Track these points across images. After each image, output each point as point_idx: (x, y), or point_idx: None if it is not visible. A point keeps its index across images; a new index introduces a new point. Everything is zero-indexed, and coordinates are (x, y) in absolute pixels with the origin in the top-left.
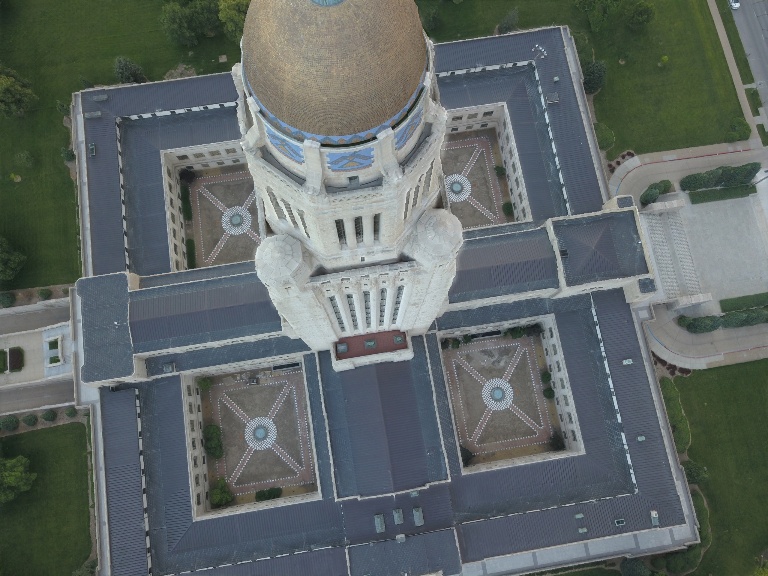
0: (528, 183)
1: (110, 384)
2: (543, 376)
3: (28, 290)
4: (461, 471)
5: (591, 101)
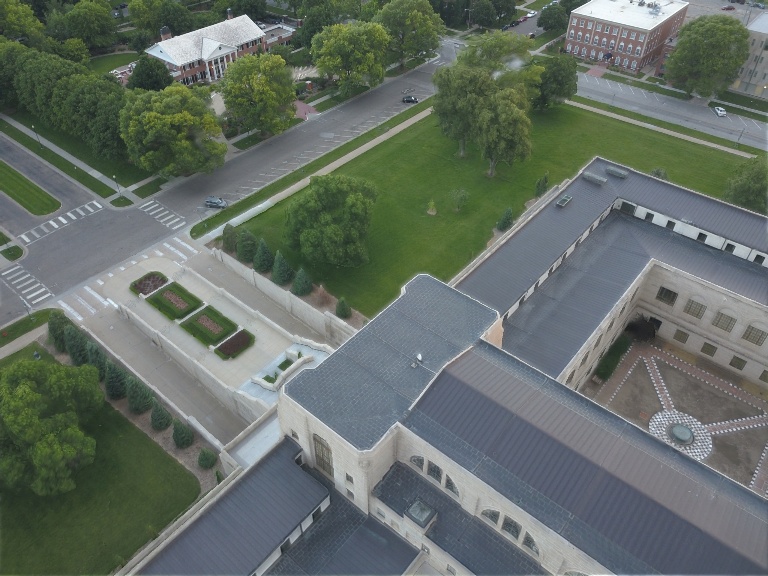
0: None
1: (308, 443)
2: None
3: (331, 297)
4: None
5: None
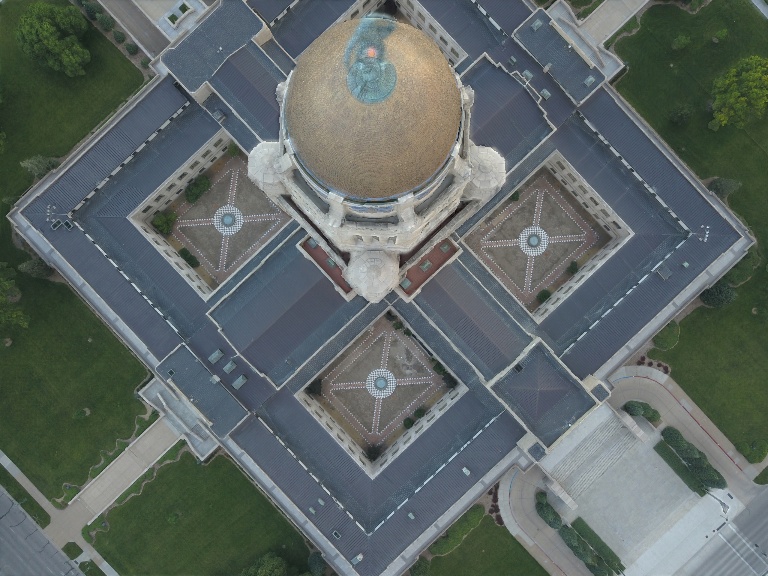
0: (571, 300)
1: None
2: (418, 410)
3: None
4: (296, 393)
5: (696, 306)
